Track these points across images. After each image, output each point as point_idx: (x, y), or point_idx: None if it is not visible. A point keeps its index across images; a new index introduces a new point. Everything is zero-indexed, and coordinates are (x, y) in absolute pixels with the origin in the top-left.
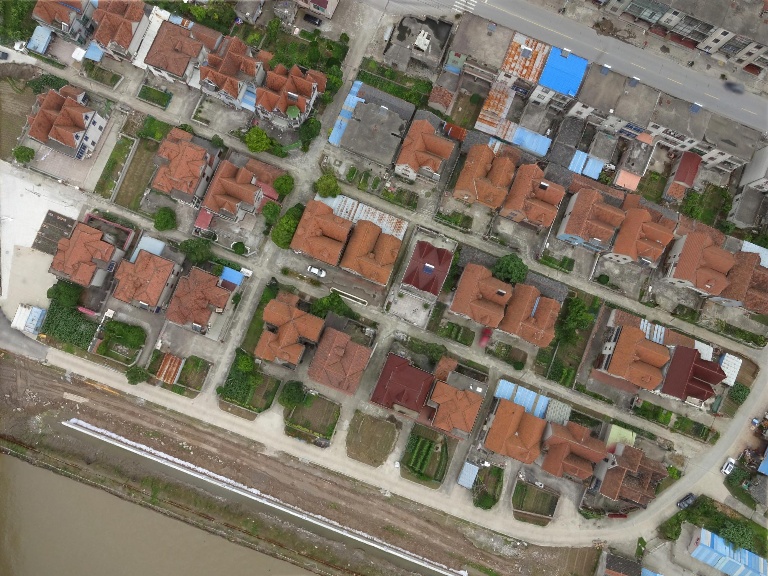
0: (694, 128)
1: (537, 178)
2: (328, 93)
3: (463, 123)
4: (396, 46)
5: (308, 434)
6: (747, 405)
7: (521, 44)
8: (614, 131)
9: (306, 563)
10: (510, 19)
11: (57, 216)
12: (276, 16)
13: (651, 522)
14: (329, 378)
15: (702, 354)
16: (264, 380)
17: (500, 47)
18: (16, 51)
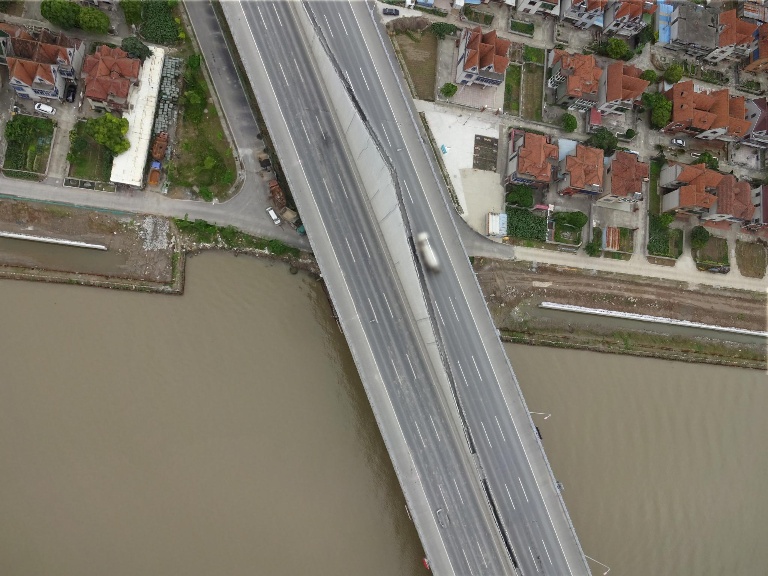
0: None
1: None
2: None
3: None
4: None
5: (713, 266)
6: None
7: None
8: None
9: (741, 362)
10: None
11: (483, 138)
12: None
13: None
14: (734, 212)
15: None
16: None
17: None
18: (403, 7)
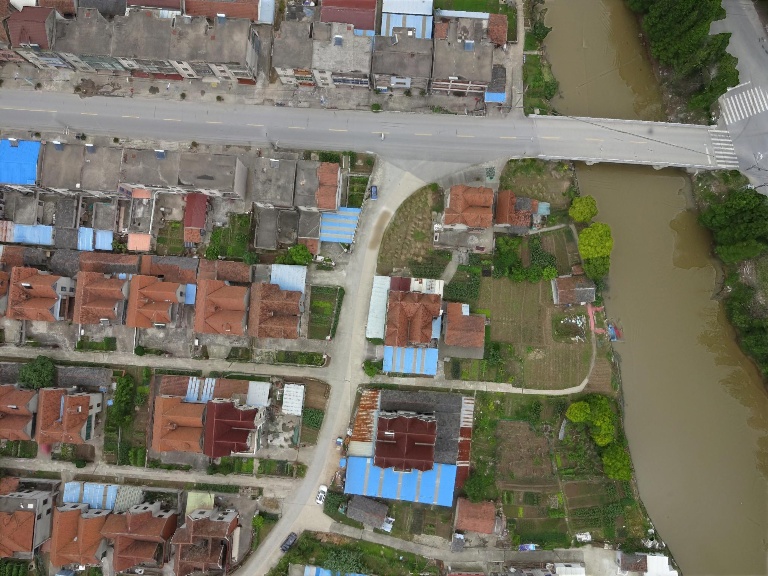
0: (166, 175)
1: (24, 279)
2: None
3: None
4: None
5: None
6: (327, 427)
7: None
8: (109, 197)
9: None
10: None
11: None
12: None
13: (260, 573)
14: None
15: (258, 394)
16: None
17: None
18: None
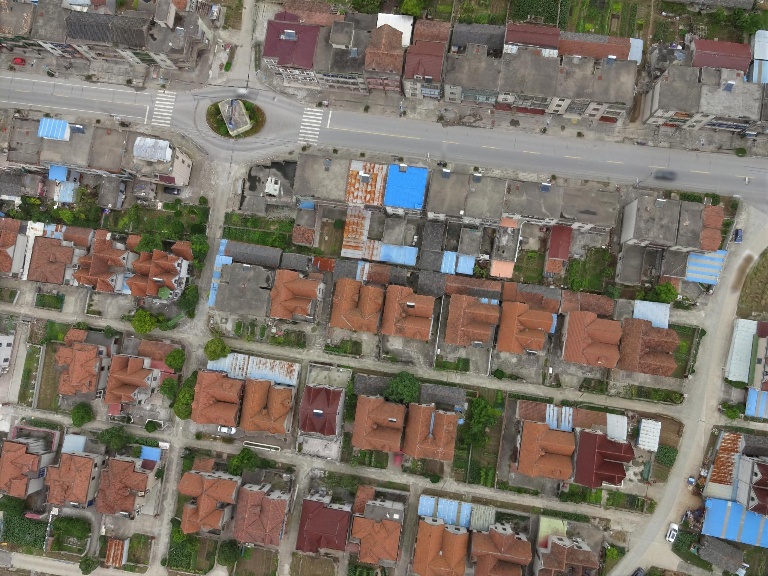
0: (549, 207)
1: (404, 297)
2: (196, 261)
3: (332, 251)
4: (250, 197)
5: None
6: (679, 465)
7: (359, 171)
8: (476, 224)
9: None
10: (355, 136)
11: None
12: (138, 197)
13: None
14: (252, 537)
15: (616, 427)
16: (203, 542)
17: (340, 179)
18: None
